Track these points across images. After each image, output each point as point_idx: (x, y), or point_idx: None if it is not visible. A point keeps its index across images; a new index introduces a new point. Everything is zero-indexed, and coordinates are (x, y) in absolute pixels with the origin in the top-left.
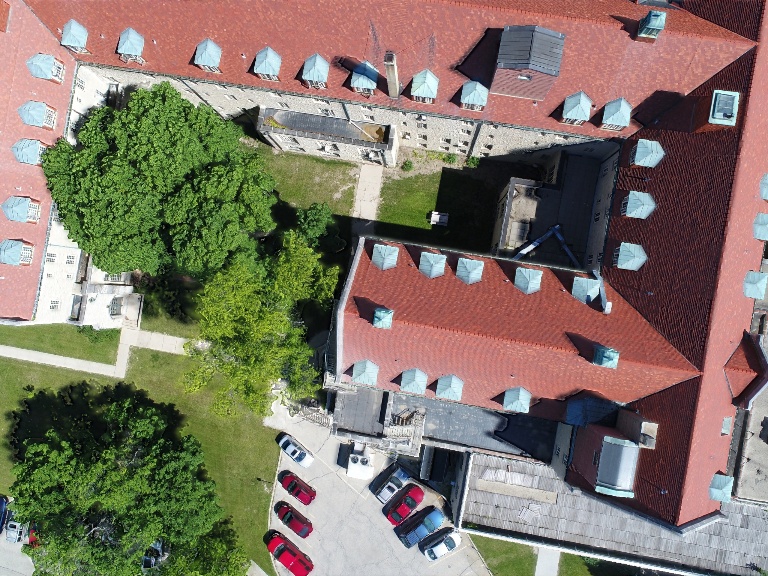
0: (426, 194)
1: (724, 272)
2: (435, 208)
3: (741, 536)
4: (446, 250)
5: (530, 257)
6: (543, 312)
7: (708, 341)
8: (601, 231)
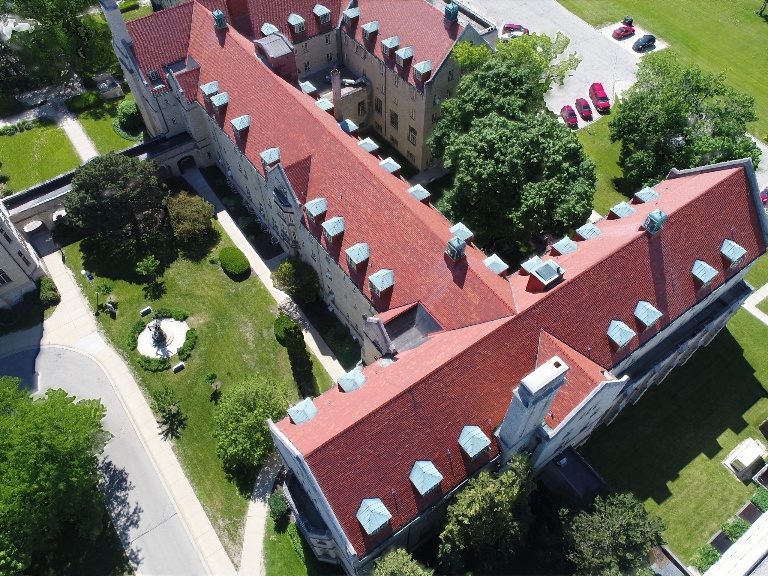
0: None
1: None
2: None
3: None
4: (390, 70)
5: None
6: (379, 5)
7: None
8: (315, 49)
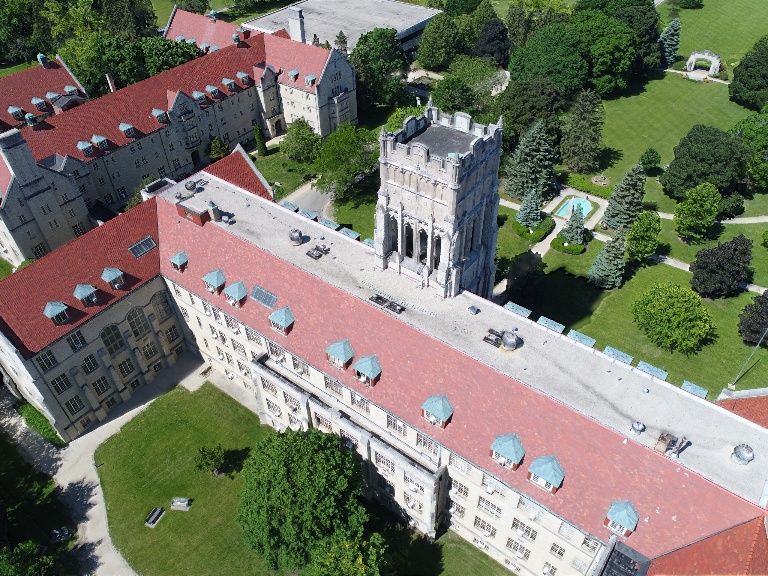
0: None
1: None
2: None
3: None
4: None
5: None
6: None
7: None
8: None
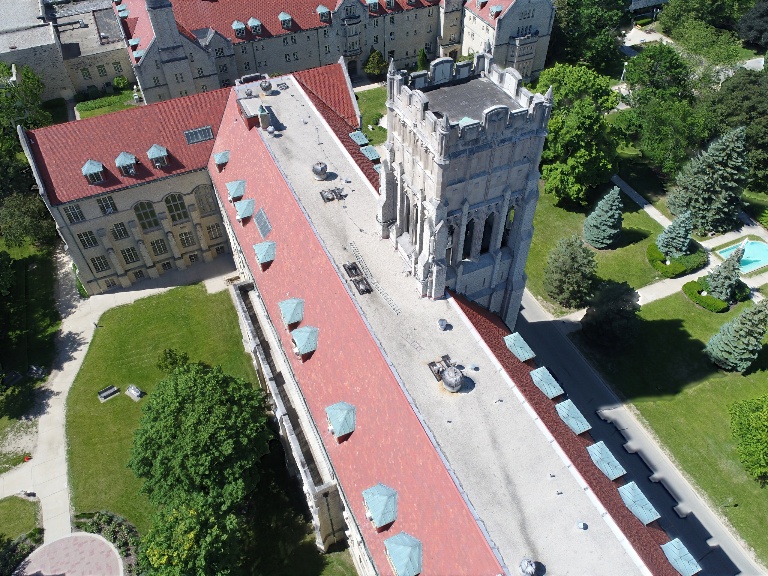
0: None
1: None
2: None
3: (85, 7)
4: None
5: None
6: None
7: None
8: None
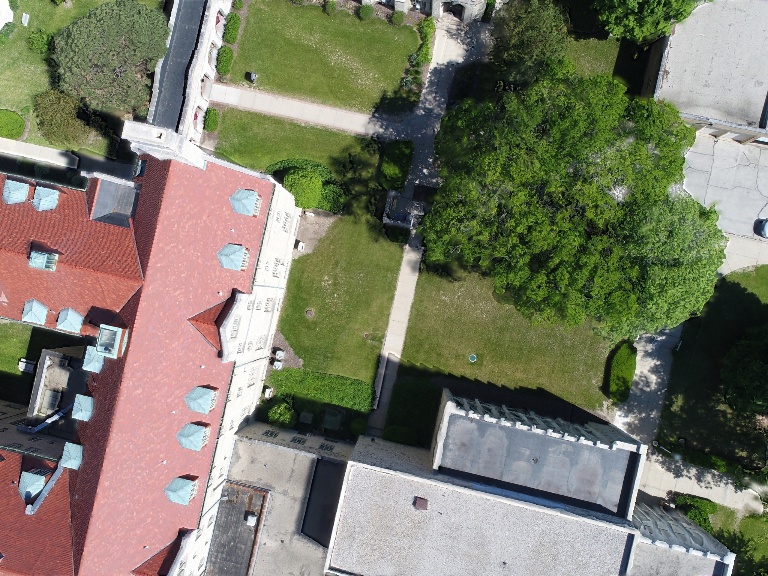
0: (19, 341)
1: (107, 492)
2: (26, 355)
3: None
4: None
5: (59, 425)
6: None
7: (81, 558)
8: None
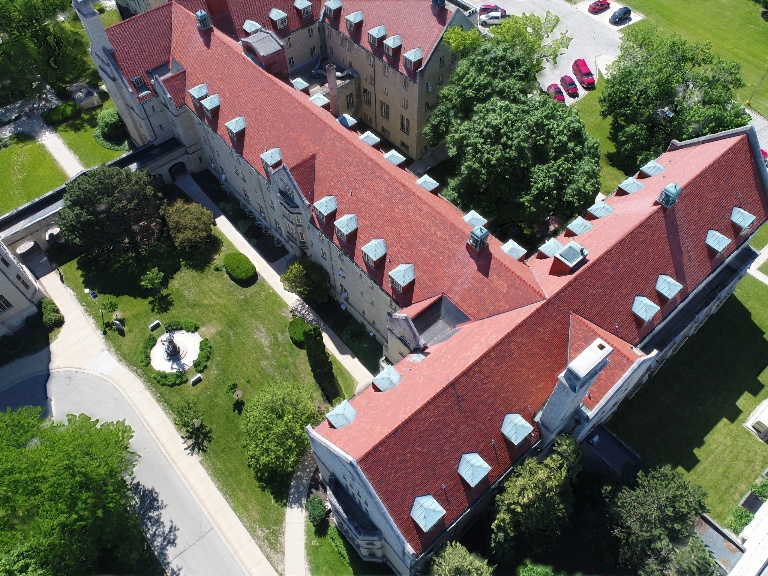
0: None
1: None
2: None
3: None
4: (379, 60)
5: None
6: None
7: None
8: None
